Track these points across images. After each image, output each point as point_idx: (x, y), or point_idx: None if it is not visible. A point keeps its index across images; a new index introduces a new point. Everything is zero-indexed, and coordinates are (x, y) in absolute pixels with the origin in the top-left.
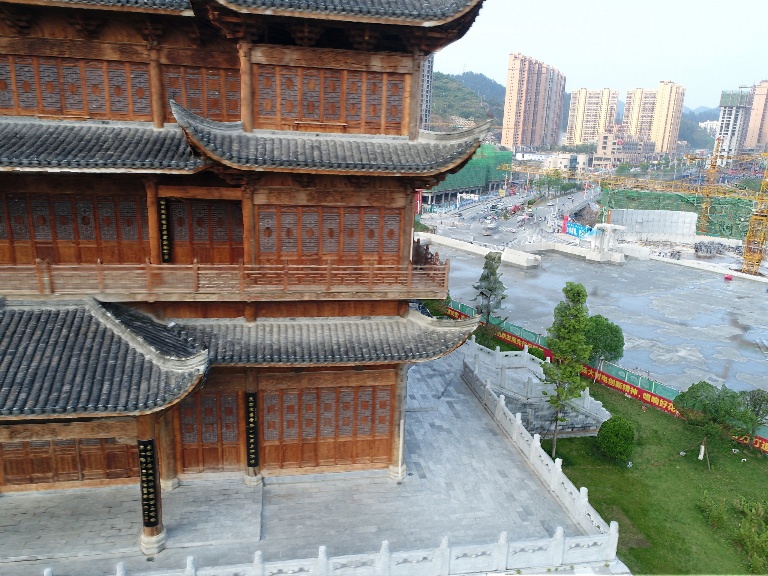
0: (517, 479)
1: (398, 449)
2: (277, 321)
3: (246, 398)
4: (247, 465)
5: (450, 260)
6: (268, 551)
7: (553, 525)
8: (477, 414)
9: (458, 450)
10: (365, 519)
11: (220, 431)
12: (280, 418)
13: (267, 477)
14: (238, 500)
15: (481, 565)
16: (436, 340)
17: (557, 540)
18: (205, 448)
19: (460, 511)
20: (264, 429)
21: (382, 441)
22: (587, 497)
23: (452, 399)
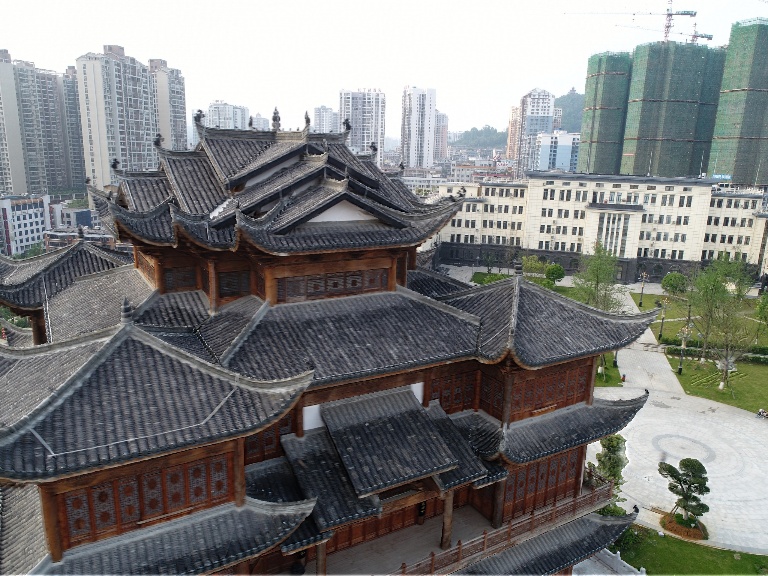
0: None
1: None
2: None
3: None
4: None
5: None
6: None
7: None
8: None
9: None
10: None
11: None
12: None
13: None
14: None
15: None
16: None
17: None
18: None
19: None
20: None
21: None
22: None
23: None
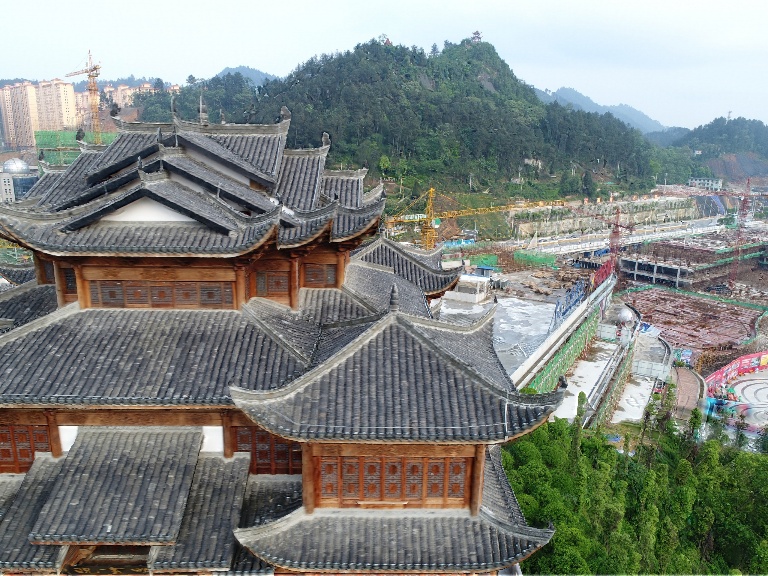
0: None
1: None
2: None
3: None
4: None
5: None
6: None
7: None
8: None
9: None
10: None
11: None
12: None
13: None
14: None
15: None
16: None
17: None
18: None
19: None
20: None
21: None
22: None
23: None
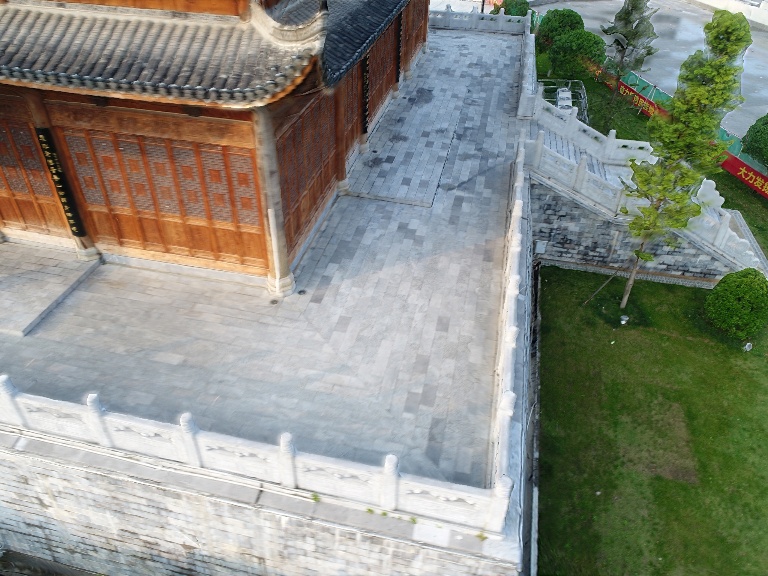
0: (458, 338)
1: (272, 253)
2: (38, 6)
3: (37, 135)
4: (72, 232)
5: (670, 15)
6: (20, 354)
7: (449, 432)
8: (486, 223)
9: (406, 271)
10: (179, 342)
11: (27, 179)
12: (98, 174)
13: (106, 253)
14: (47, 276)
15: (253, 469)
16: (269, 67)
17: (384, 475)
18: (17, 199)
19: (321, 367)
20: (82, 187)
21: (252, 236)
22: (512, 409)
23: (468, 194)
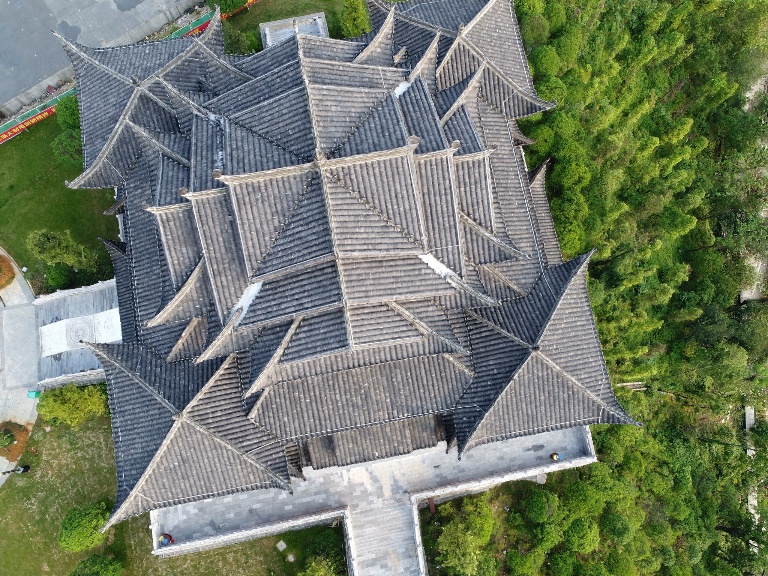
0: None
1: None
2: None
3: None
4: None
5: None
6: None
7: None
8: None
9: None
10: None
11: None
12: None
13: None
14: None
15: None
16: None
17: None
18: None
19: None
20: None
21: None
22: None
23: None
